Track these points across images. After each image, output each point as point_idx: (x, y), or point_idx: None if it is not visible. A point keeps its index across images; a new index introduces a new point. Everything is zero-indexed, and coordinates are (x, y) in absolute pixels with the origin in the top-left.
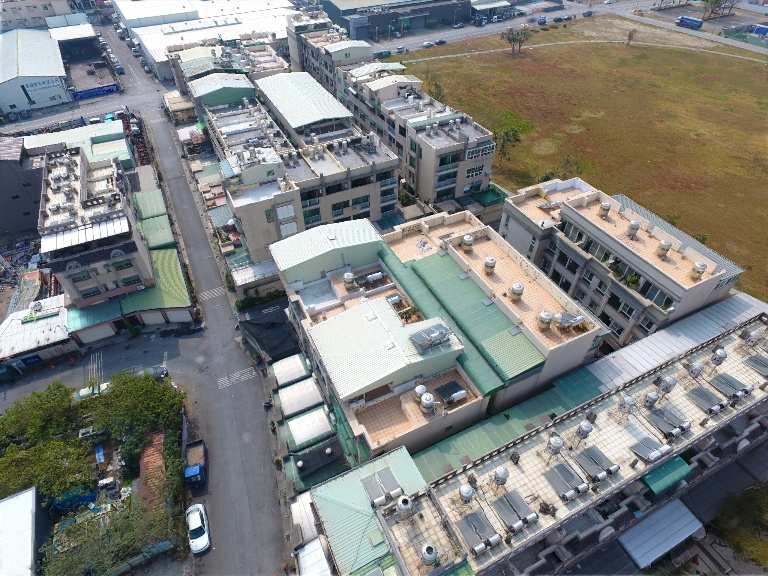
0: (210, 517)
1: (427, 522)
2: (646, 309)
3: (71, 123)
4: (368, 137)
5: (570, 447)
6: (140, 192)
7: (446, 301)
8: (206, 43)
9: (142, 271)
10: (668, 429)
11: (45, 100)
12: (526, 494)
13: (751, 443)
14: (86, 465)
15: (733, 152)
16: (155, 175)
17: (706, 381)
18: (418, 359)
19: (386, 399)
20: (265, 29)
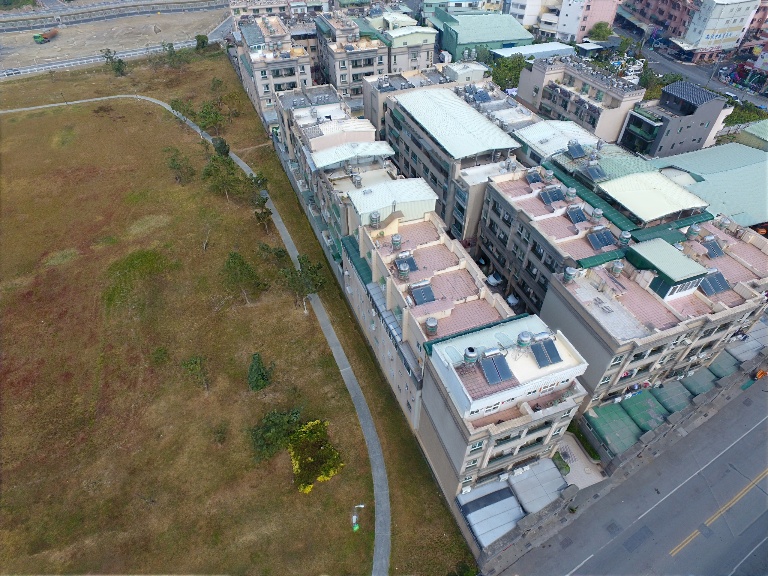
0: None
1: None
2: None
3: None
4: (382, 95)
5: None
6: None
7: None
8: None
9: None
10: None
11: None
12: None
13: None
14: None
15: None
16: None
17: None
18: None
19: None
20: None
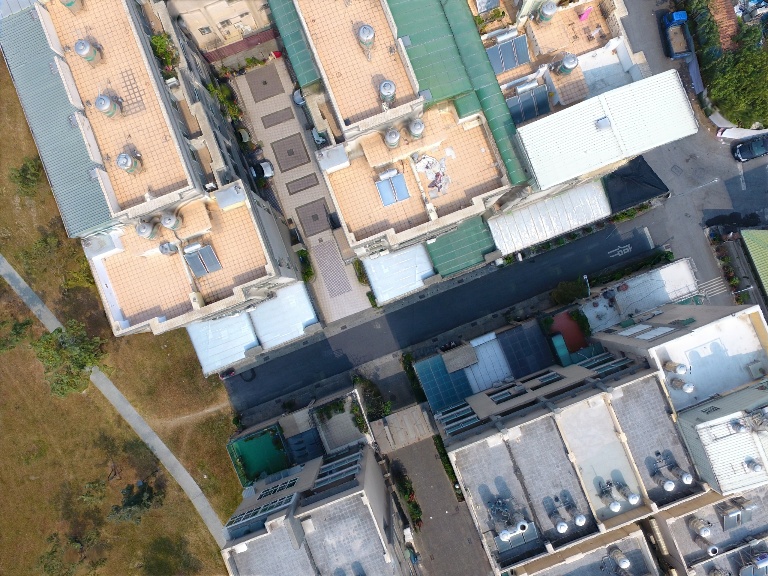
0: None
1: None
2: None
3: None
4: (504, 567)
5: None
6: None
7: (438, 4)
8: None
9: None
10: None
11: None
12: None
13: None
14: None
15: None
16: None
17: None
18: None
19: None
20: None
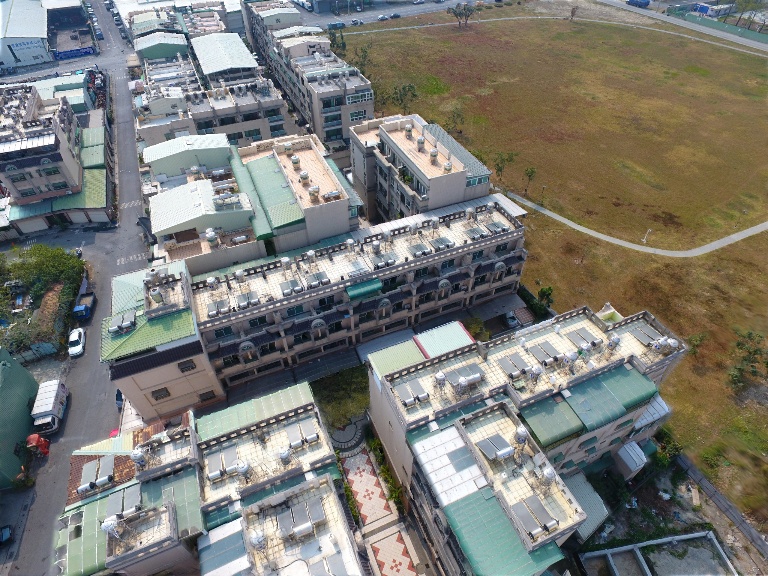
0: (88, 338)
1: (176, 292)
2: (414, 199)
3: (47, 77)
4: (267, 84)
5: (306, 271)
6: (88, 128)
7: (257, 185)
8: (163, 9)
9: (68, 178)
10: (378, 263)
11: (29, 59)
12: (262, 293)
13: (452, 283)
14: (5, 301)
15: (617, 112)
16: (104, 117)
17: (428, 241)
18: (213, 212)
19: (195, 243)
20: (230, 1)
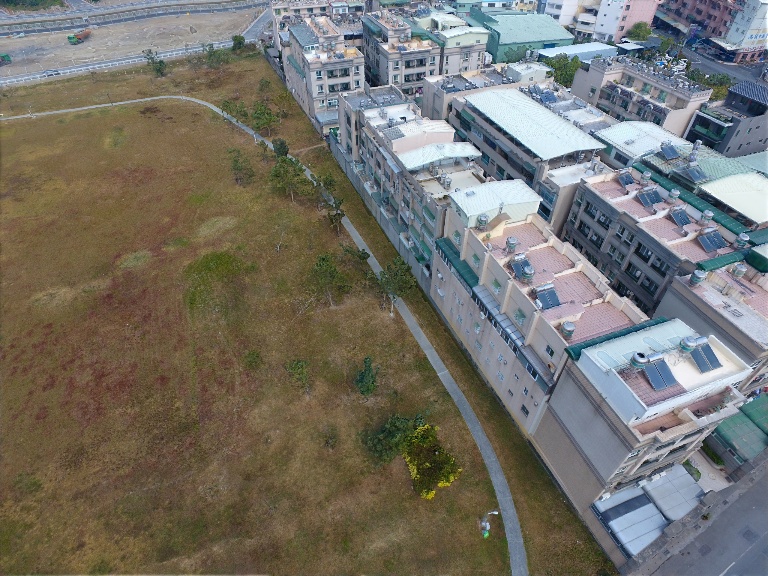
0: None
1: None
2: None
3: None
4: (448, 96)
5: None
6: None
7: None
8: None
9: None
10: None
11: None
12: None
13: None
14: None
15: (7, 206)
16: None
17: None
18: None
19: None
20: None
